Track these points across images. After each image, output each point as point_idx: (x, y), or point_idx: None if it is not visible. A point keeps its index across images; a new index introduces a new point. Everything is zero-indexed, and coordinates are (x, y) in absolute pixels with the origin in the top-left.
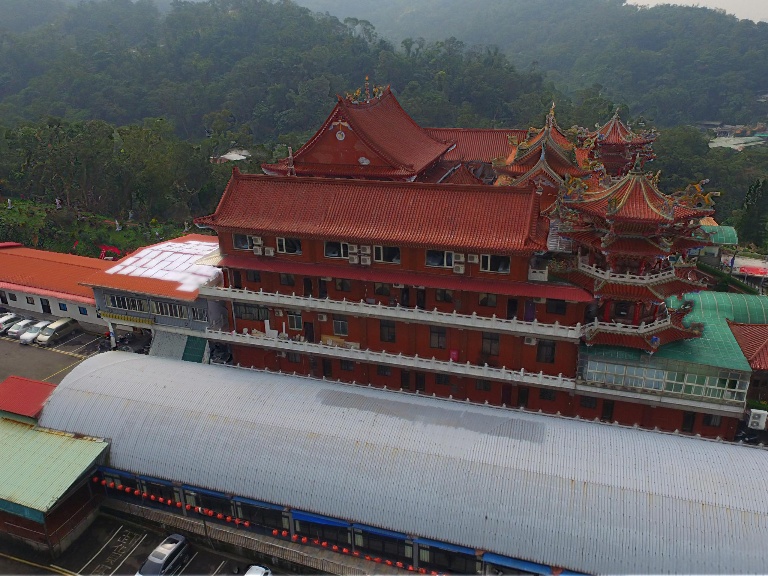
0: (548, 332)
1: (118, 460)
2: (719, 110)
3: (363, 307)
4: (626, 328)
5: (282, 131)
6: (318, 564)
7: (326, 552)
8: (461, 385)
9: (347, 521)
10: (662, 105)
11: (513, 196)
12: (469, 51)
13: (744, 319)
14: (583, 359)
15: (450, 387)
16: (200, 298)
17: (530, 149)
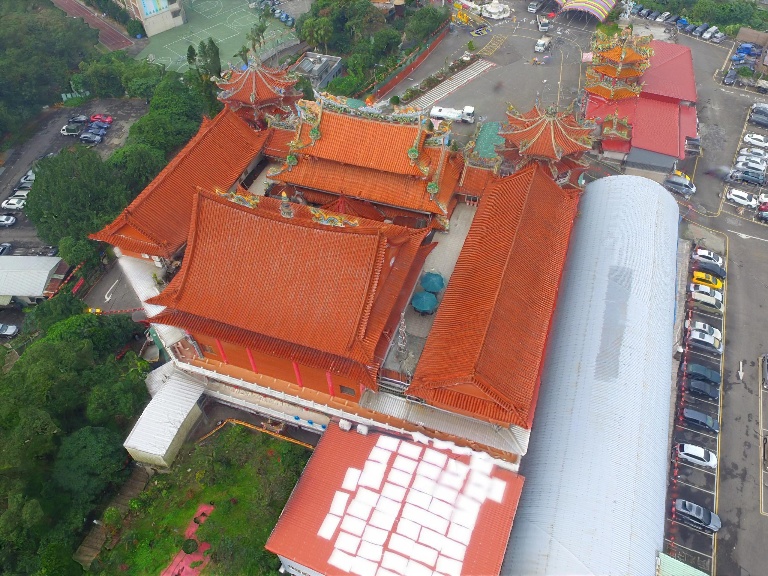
0: None
1: None
2: None
3: None
4: None
5: None
6: None
7: None
8: None
9: None
10: None
11: None
12: None
13: None
14: None
15: None
16: None
17: None
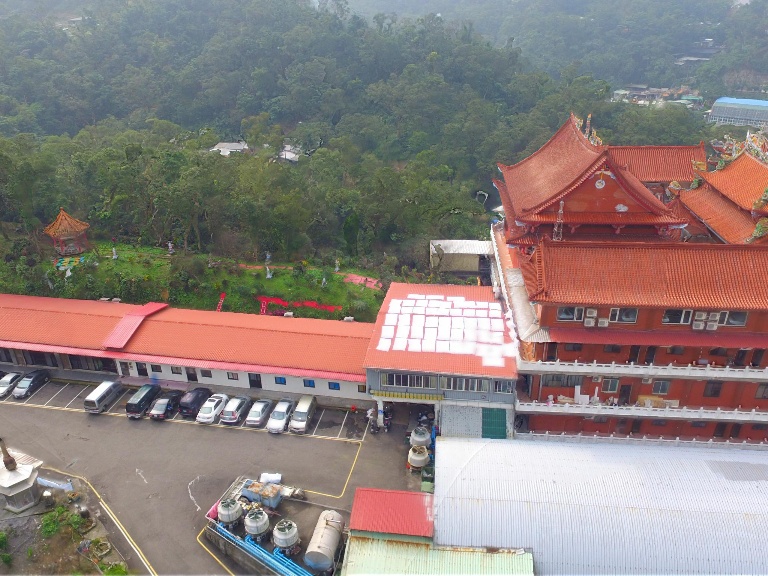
0: None
1: (546, 569)
2: (645, 74)
3: (709, 371)
4: None
5: (274, 120)
6: None
7: None
8: None
9: None
10: (596, 70)
11: None
12: (449, 28)
13: None
14: None
15: (766, 432)
16: (520, 374)
17: None
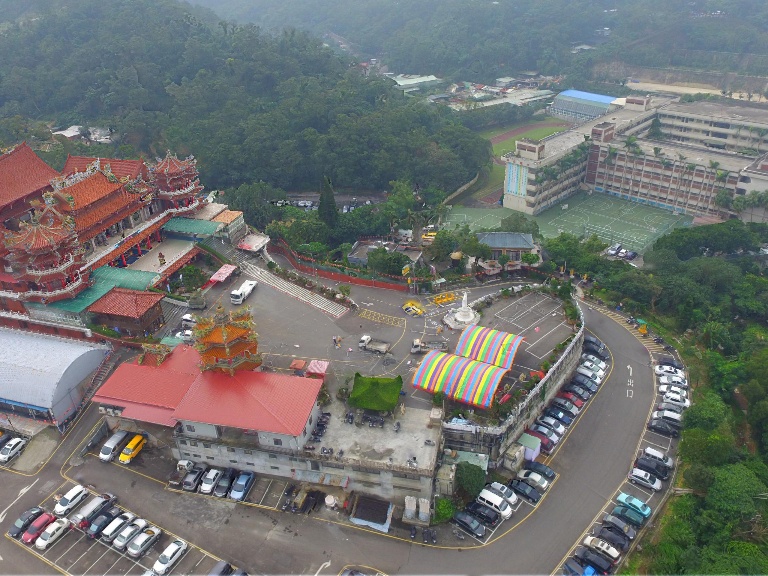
0: (10, 296)
1: None
2: None
3: None
4: (43, 294)
5: (107, 110)
6: None
7: None
8: (1, 319)
9: None
10: (487, 58)
11: None
12: (264, 35)
13: (124, 286)
14: (27, 308)
15: None
16: None
17: None
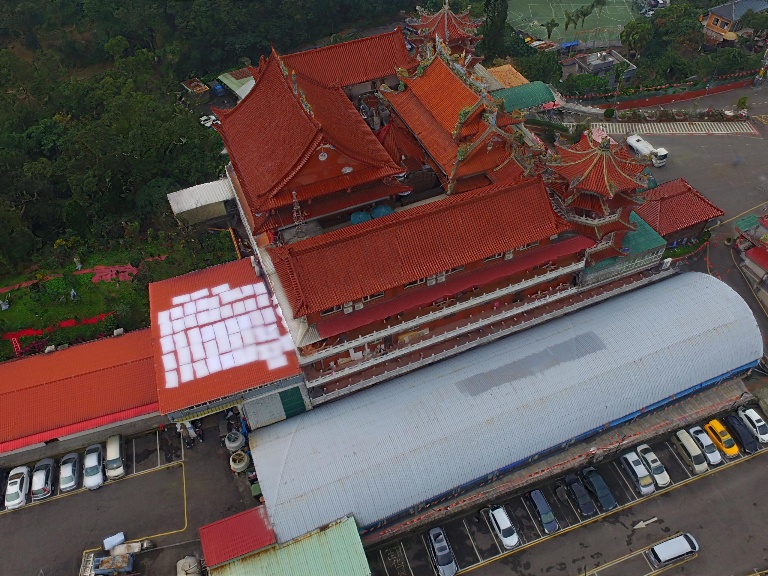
0: (568, 271)
1: (366, 521)
2: None
3: (446, 311)
4: (603, 245)
5: None
6: (524, 484)
7: (516, 474)
8: None
9: (535, 454)
10: None
11: (528, 189)
12: None
13: None
14: (585, 275)
15: None
16: (303, 367)
17: (472, 111)
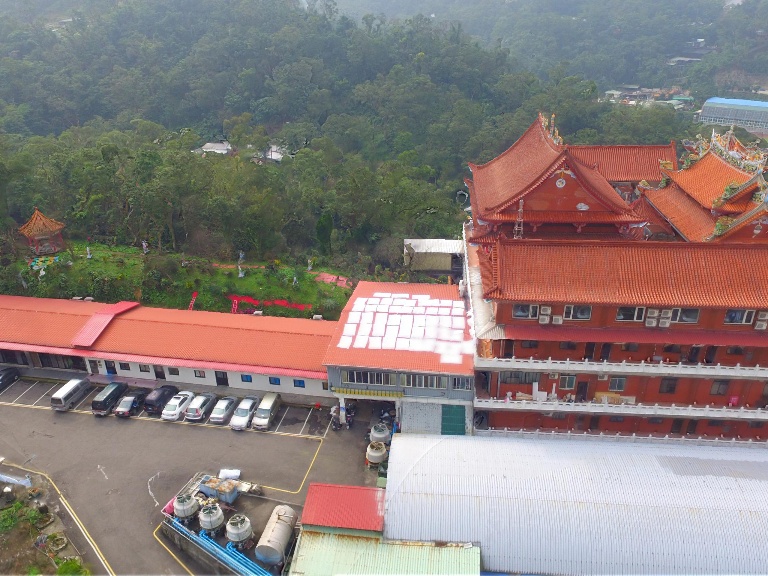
0: None
1: (493, 563)
2: (636, 74)
3: (662, 368)
4: None
5: (261, 121)
6: None
7: None
8: (735, 425)
9: None
10: (587, 71)
11: None
12: (437, 29)
13: None
14: None
15: (722, 428)
16: (476, 371)
17: (741, 188)
